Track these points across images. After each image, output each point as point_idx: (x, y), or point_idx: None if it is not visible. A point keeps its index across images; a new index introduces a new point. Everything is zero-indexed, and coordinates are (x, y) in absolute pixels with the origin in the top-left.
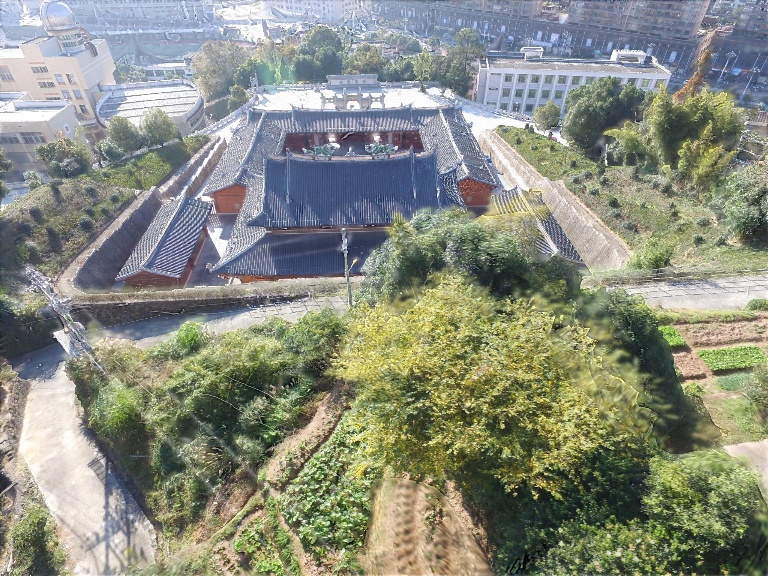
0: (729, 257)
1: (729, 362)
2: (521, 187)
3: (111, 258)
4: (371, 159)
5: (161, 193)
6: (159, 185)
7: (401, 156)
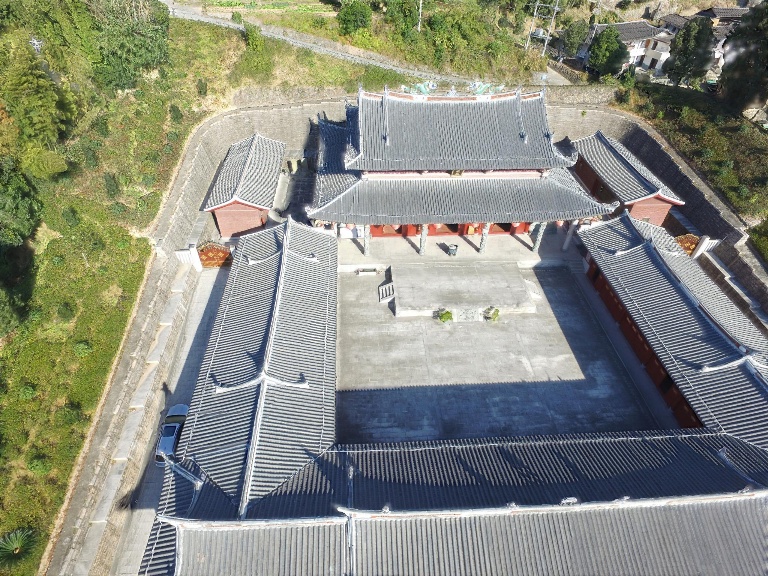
0: (183, 60)
1: (278, 7)
2: (183, 293)
3: (655, 164)
4: (430, 100)
5: (736, 246)
6: (765, 264)
7: (397, 97)
